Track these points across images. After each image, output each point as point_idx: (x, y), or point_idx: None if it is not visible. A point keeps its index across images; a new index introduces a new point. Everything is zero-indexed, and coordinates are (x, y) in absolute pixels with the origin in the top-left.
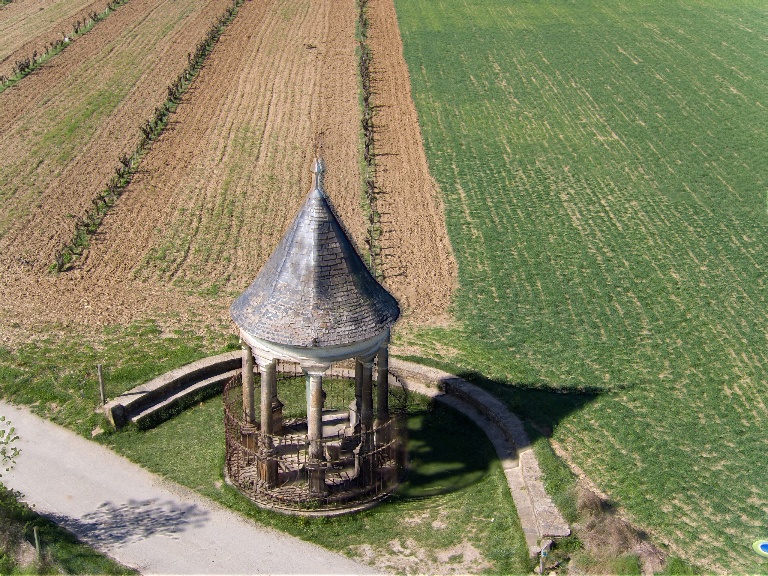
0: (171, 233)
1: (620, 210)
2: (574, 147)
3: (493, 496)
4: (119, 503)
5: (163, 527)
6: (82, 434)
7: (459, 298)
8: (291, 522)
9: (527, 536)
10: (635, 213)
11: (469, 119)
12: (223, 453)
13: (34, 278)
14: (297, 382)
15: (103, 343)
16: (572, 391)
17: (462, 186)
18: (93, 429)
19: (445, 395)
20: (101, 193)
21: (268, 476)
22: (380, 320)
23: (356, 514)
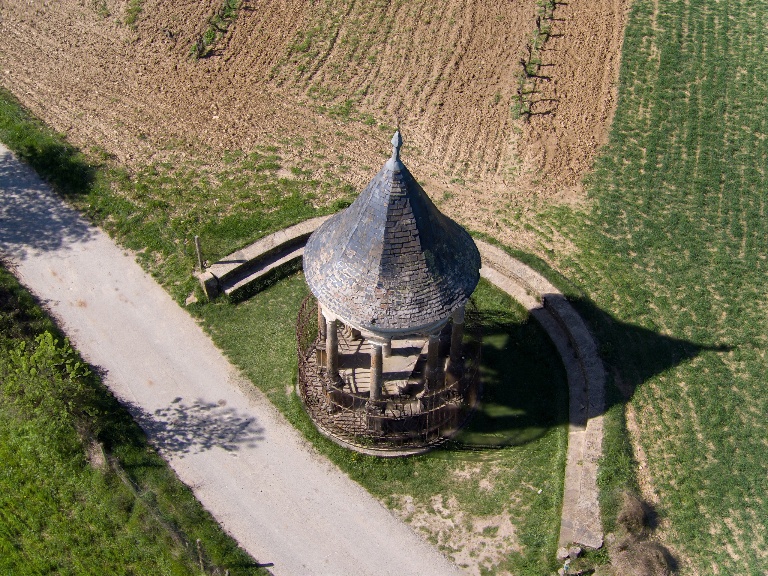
0: (324, 7)
1: None
2: None
3: (550, 459)
4: (193, 400)
5: (226, 438)
6: (177, 300)
7: (601, 162)
8: (344, 456)
9: (562, 531)
10: None
11: None
12: (302, 352)
13: (173, 63)
14: None
15: (219, 177)
16: (676, 334)
17: None
18: (188, 296)
19: (542, 310)
20: None
21: (331, 403)
22: (449, 300)
23: (408, 458)
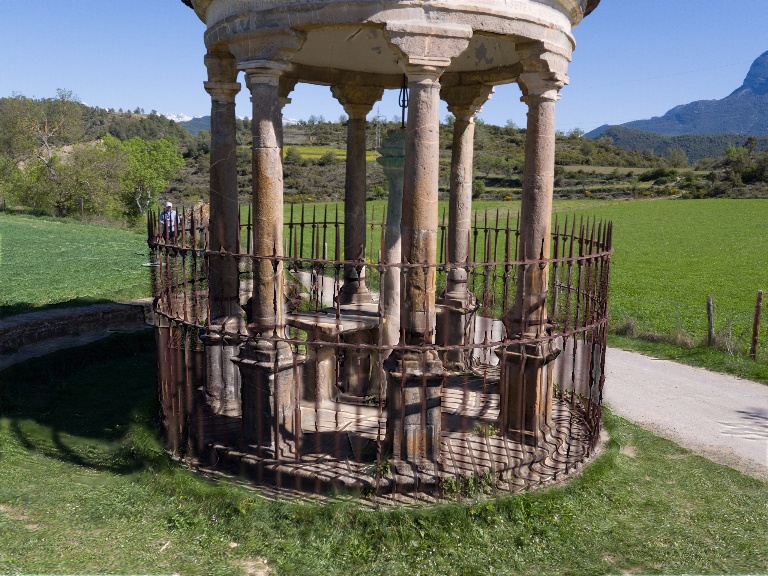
0: None
1: None
2: None
3: None
4: None
5: None
6: None
7: None
8: None
9: None
10: None
11: None
12: (589, 472)
13: None
14: None
15: None
16: None
17: None
18: None
19: None
20: None
21: None
22: None
23: None
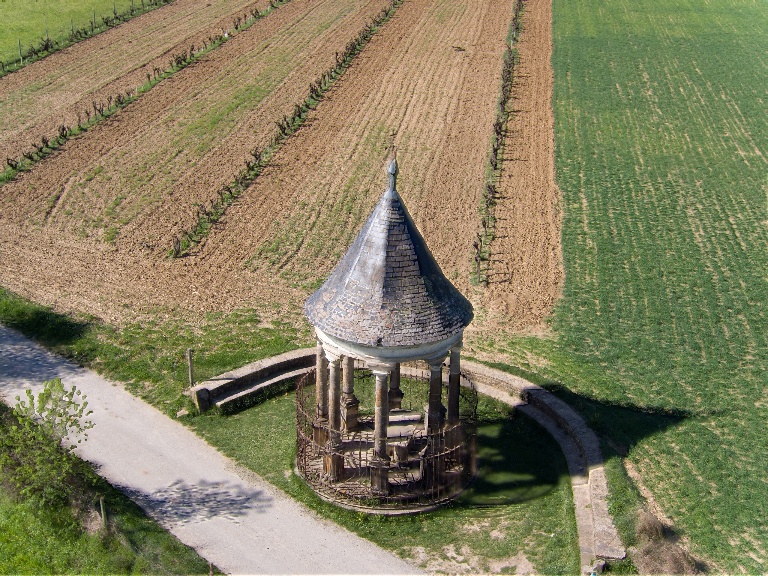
0: (288, 226)
1: (747, 229)
2: (711, 161)
3: (557, 511)
4: (190, 483)
5: (227, 510)
6: (168, 414)
7: (560, 308)
8: (350, 517)
9: (582, 555)
10: (763, 233)
11: (606, 128)
12: None
13: (151, 262)
14: None
15: (202, 328)
16: (658, 411)
17: (586, 195)
18: (179, 410)
19: (527, 405)
20: (230, 184)
21: (333, 470)
22: (449, 324)
23: (415, 516)
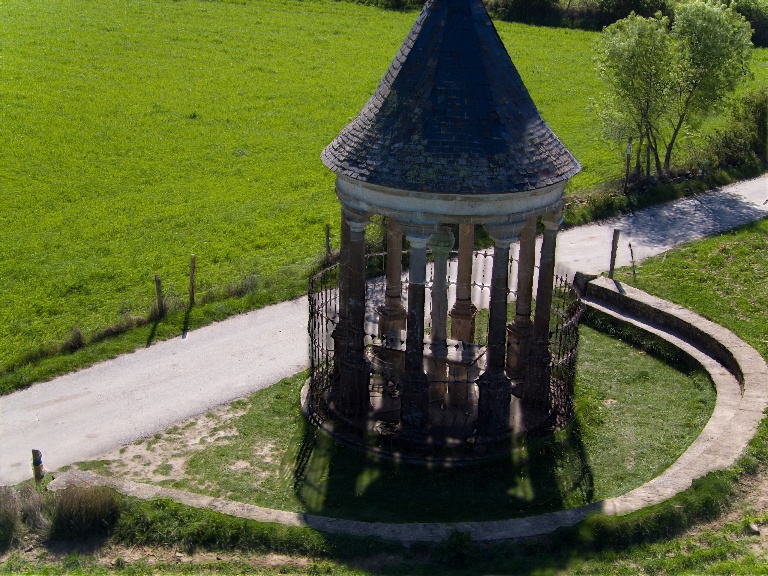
0: None
1: None
2: None
3: None
4: None
5: None
6: None
7: None
8: None
9: None
10: None
11: None
12: None
13: None
14: (702, 419)
15: None
16: None
17: None
18: None
19: None
20: None
21: (379, 335)
22: (355, 161)
23: None
